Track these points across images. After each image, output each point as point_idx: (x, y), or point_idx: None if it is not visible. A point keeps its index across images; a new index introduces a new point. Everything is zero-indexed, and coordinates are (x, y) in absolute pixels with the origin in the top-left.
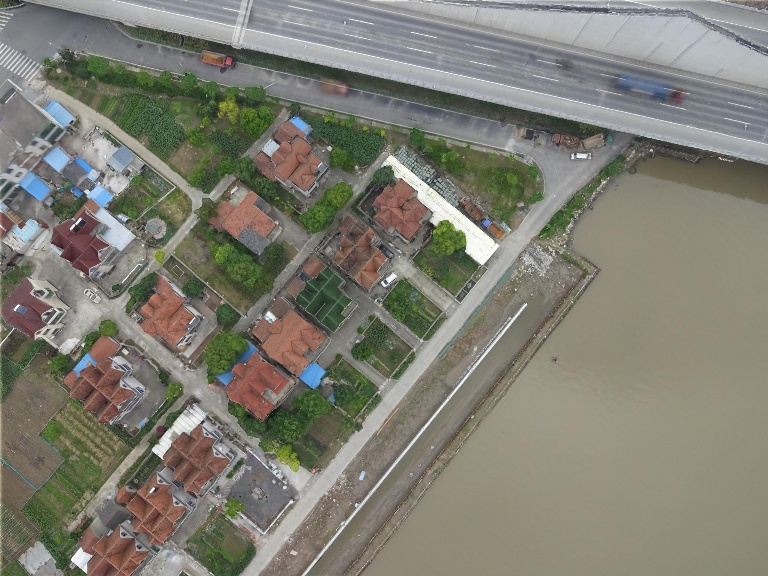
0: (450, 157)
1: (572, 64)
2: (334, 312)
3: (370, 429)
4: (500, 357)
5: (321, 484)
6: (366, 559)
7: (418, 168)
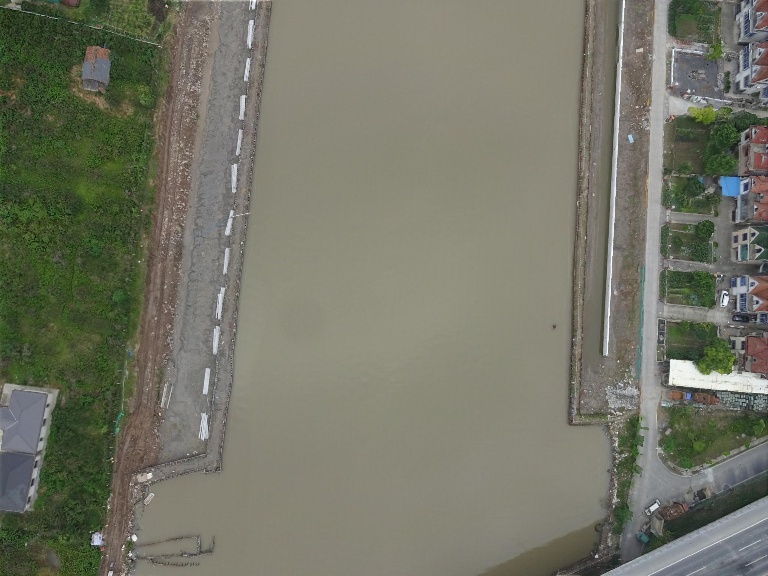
0: (760, 427)
1: (739, 573)
2: (767, 241)
3: (654, 176)
4: (593, 300)
5: (659, 112)
6: (588, 80)
7: (767, 402)
